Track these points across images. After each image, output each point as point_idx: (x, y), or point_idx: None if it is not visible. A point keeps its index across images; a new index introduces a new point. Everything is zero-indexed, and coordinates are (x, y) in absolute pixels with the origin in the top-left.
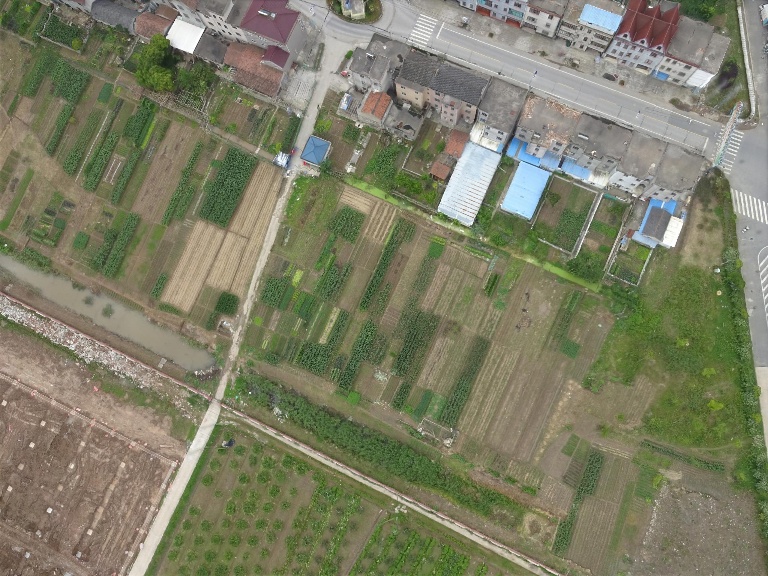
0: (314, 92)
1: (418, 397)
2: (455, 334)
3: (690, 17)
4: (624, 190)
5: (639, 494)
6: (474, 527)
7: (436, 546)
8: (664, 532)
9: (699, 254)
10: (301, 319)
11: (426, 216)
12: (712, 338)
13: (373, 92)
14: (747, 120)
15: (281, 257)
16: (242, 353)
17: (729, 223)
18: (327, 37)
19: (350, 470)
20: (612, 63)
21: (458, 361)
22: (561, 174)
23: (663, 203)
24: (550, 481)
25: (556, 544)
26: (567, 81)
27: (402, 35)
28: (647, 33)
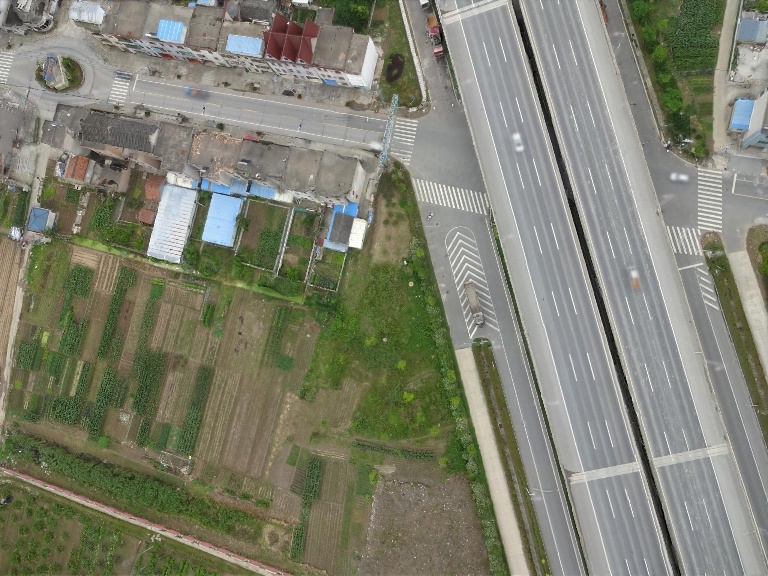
0: (37, 165)
1: (158, 432)
2: (183, 367)
3: (345, 20)
4: (313, 201)
5: (359, 492)
6: (220, 545)
7: (190, 568)
8: (382, 526)
9: (388, 249)
10: (52, 377)
11: (145, 261)
12: (407, 330)
13: (72, 157)
14: (420, 107)
15: (29, 323)
16: (8, 417)
17: (413, 213)
18: (41, 111)
19: (105, 509)
20: (289, 79)
21: (188, 392)
22: (255, 197)
23: (344, 207)
24: (280, 492)
25: (291, 551)
26: (251, 106)
27: (103, 95)
28: (282, 51)
